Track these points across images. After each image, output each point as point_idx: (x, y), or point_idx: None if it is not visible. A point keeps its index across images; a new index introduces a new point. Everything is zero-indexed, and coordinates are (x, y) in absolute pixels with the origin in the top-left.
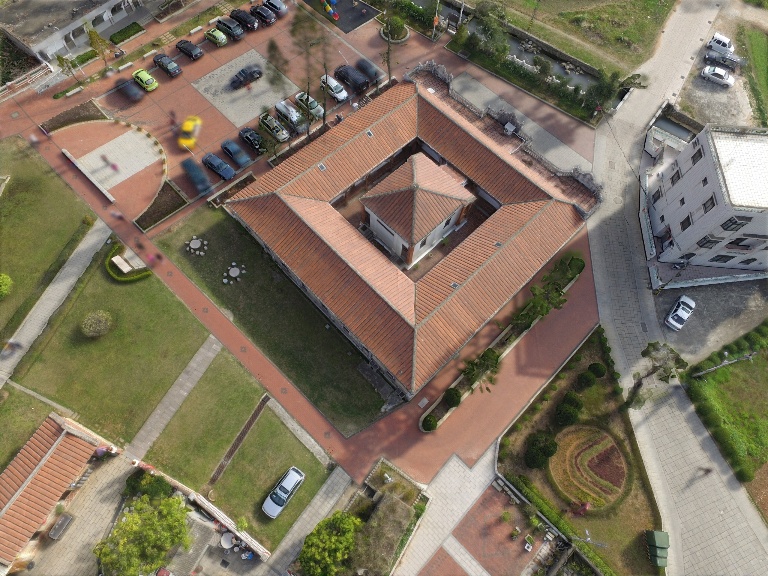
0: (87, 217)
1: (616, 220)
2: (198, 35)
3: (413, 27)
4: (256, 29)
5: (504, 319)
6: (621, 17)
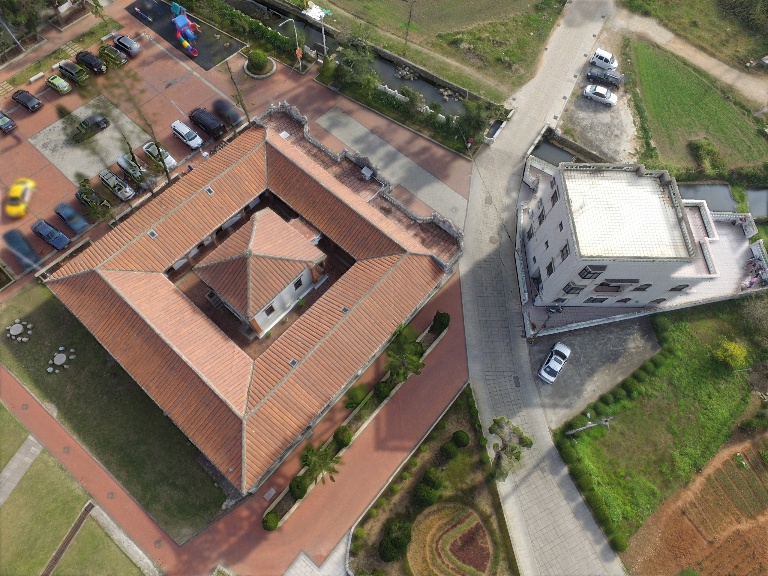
0: None
1: (491, 262)
2: (40, 83)
3: (280, 59)
4: (105, 72)
5: (364, 386)
6: (503, 35)
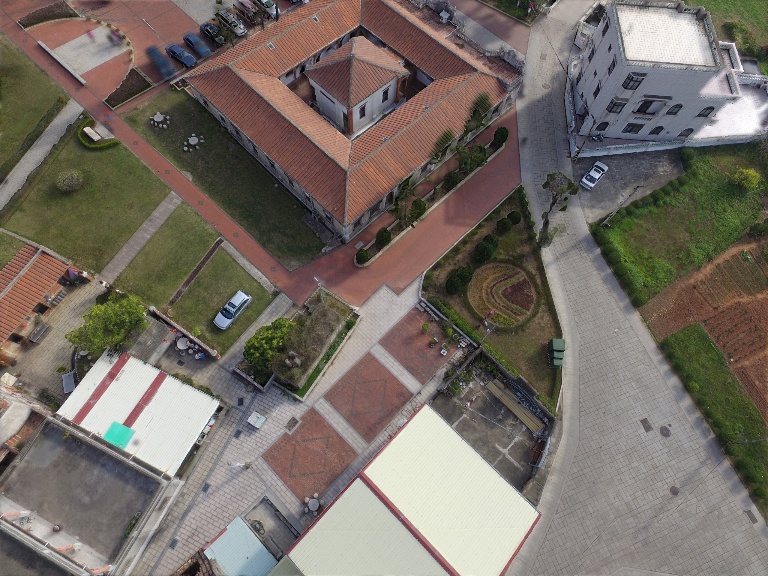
0: (61, 97)
1: (543, 102)
2: None
3: None
4: None
5: (435, 180)
6: None
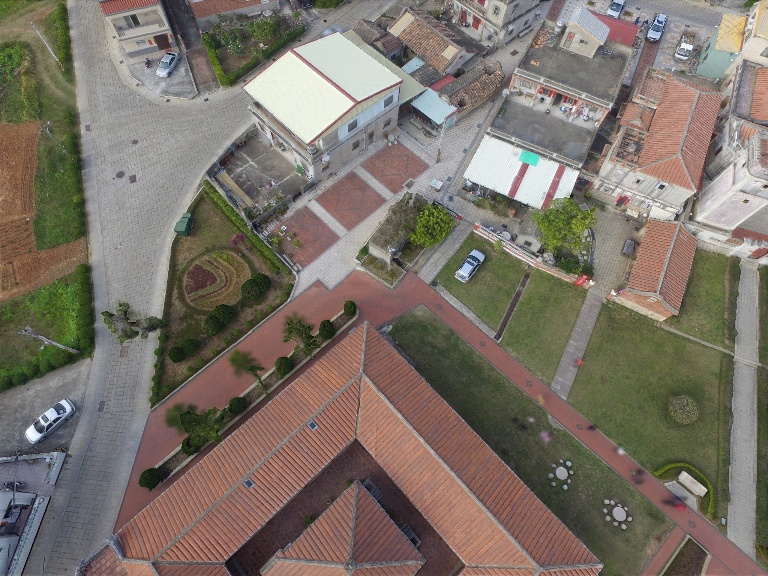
0: None
1: (59, 568)
2: None
3: None
4: None
5: None
6: None
